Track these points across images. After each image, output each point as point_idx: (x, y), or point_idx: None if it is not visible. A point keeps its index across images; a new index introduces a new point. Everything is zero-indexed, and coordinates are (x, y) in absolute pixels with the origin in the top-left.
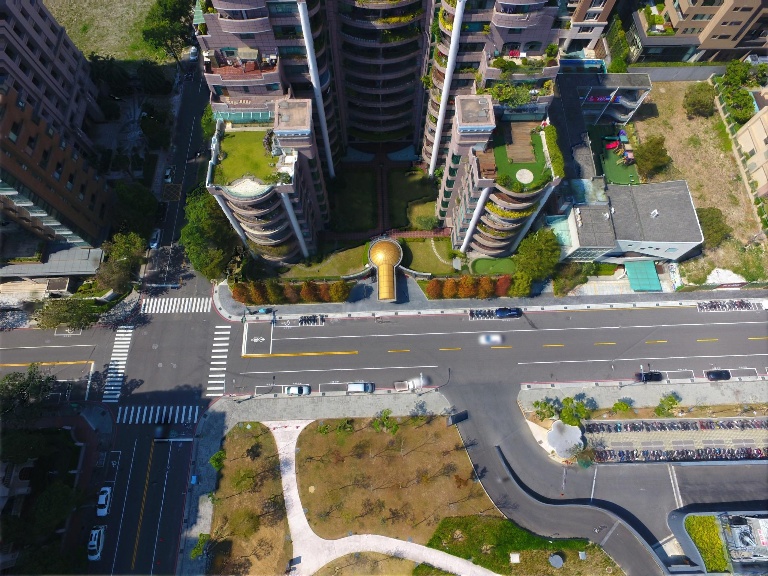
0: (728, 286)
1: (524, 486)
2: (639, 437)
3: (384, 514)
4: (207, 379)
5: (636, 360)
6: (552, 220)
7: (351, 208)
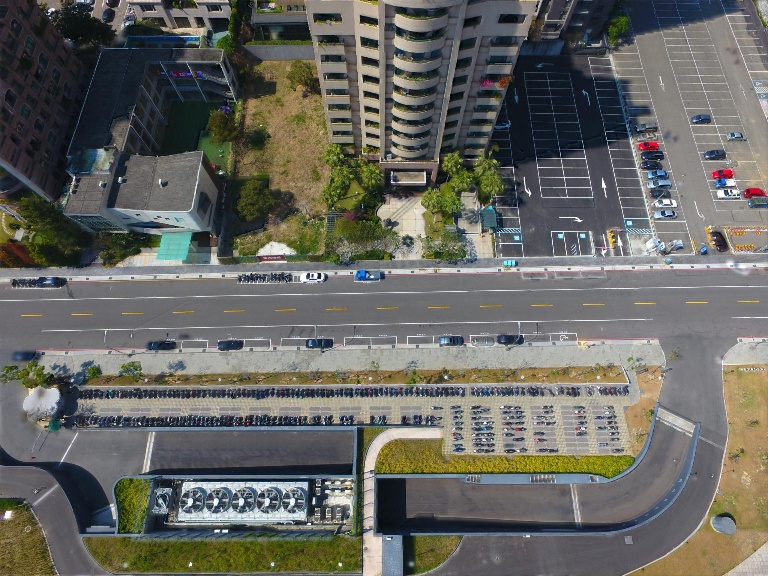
0: (271, 259)
1: None
2: (130, 404)
3: None
4: None
5: (157, 329)
6: None
7: None
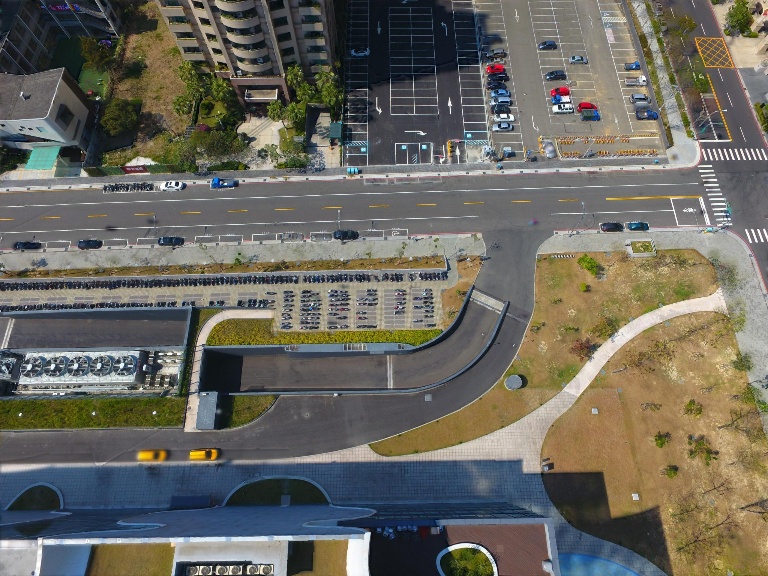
0: (135, 170)
1: None
2: None
3: None
4: None
5: (25, 233)
6: None
7: None
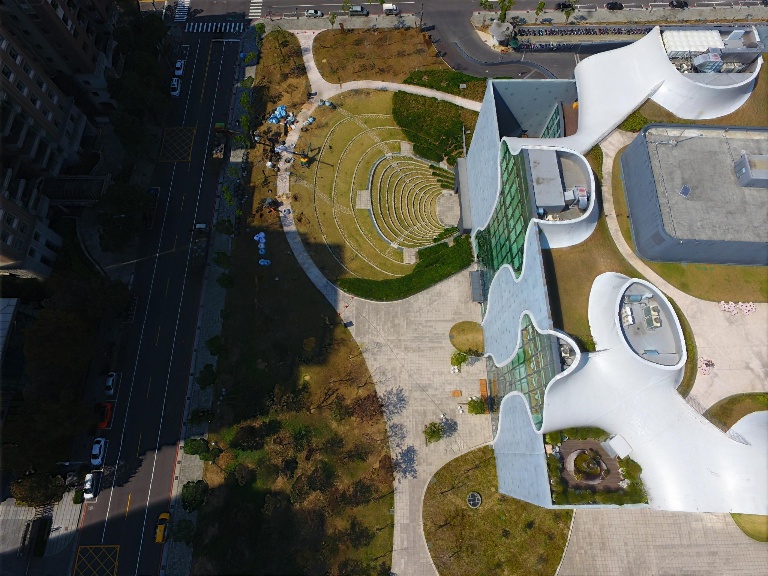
0: None
1: None
2: (555, 38)
3: (374, 70)
4: (249, 9)
5: None
6: None
7: None
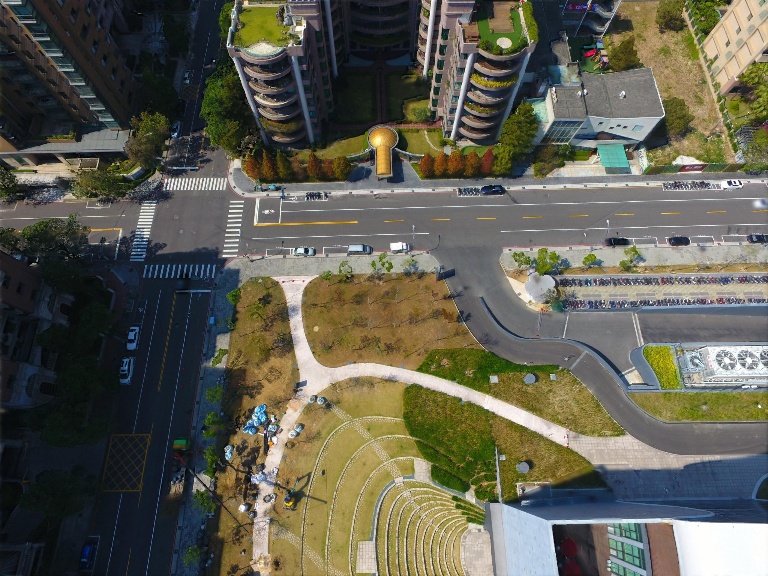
0: (690, 169)
1: (504, 328)
2: (607, 290)
3: (380, 347)
4: (223, 243)
5: (606, 229)
6: (532, 102)
7: (352, 104)
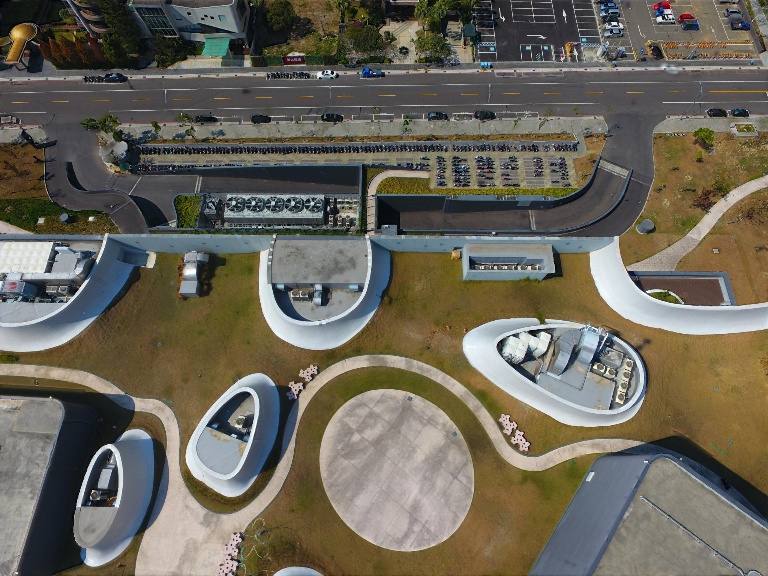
0: (293, 61)
1: (79, 186)
2: (182, 158)
3: None
4: None
5: (202, 110)
6: None
7: (20, 10)
